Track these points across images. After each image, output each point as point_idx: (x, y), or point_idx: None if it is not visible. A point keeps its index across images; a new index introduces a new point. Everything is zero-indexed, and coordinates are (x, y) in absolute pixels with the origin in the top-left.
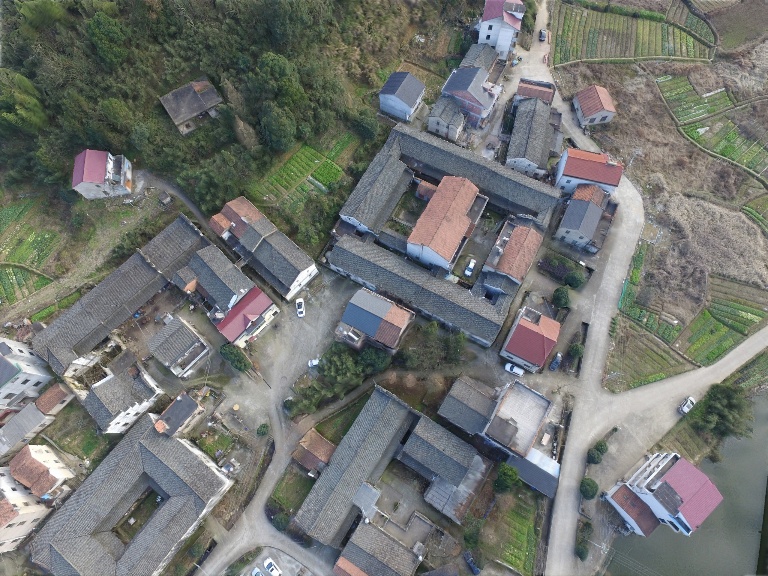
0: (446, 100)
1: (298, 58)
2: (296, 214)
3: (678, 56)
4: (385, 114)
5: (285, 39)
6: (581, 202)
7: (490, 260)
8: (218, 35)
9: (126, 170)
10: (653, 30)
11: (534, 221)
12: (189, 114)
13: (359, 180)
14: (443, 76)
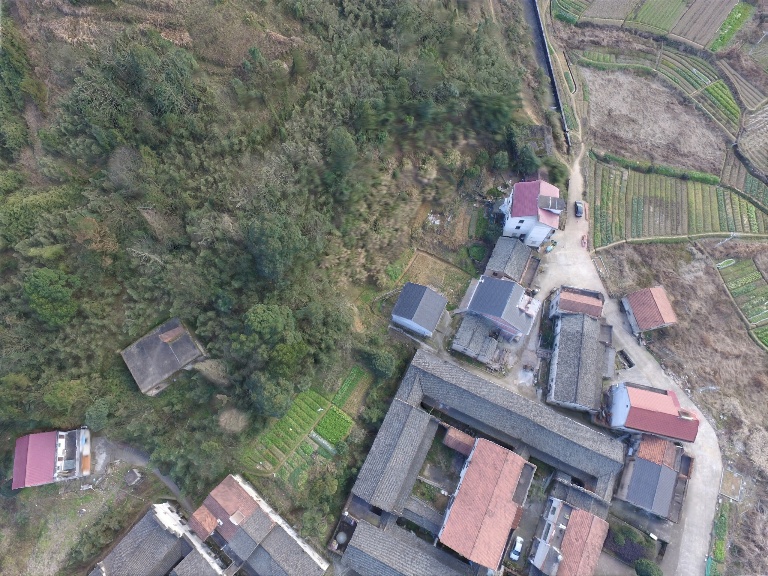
0: (474, 321)
1: (292, 290)
2: (298, 488)
3: (740, 232)
4: (399, 326)
5: (275, 275)
6: (650, 464)
7: (547, 569)
8: (191, 271)
9: (82, 447)
10: (707, 196)
11: (595, 498)
12: (159, 376)
13: (373, 431)
14: (465, 269)
